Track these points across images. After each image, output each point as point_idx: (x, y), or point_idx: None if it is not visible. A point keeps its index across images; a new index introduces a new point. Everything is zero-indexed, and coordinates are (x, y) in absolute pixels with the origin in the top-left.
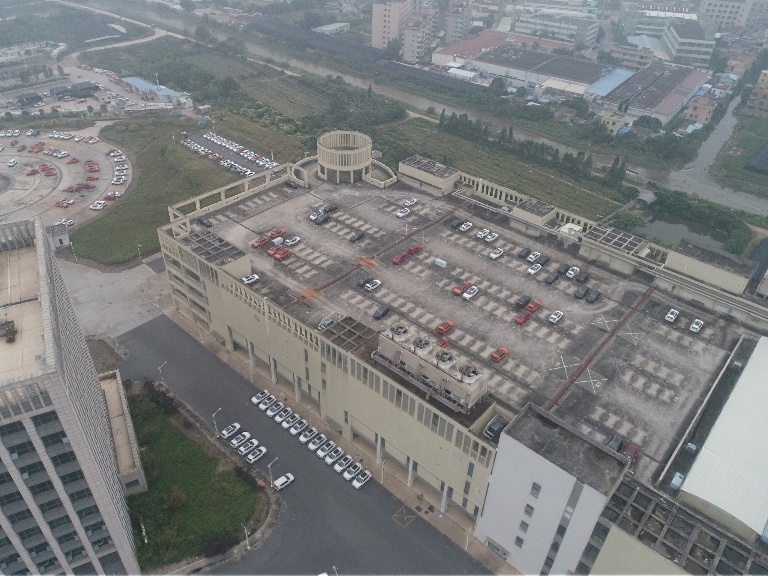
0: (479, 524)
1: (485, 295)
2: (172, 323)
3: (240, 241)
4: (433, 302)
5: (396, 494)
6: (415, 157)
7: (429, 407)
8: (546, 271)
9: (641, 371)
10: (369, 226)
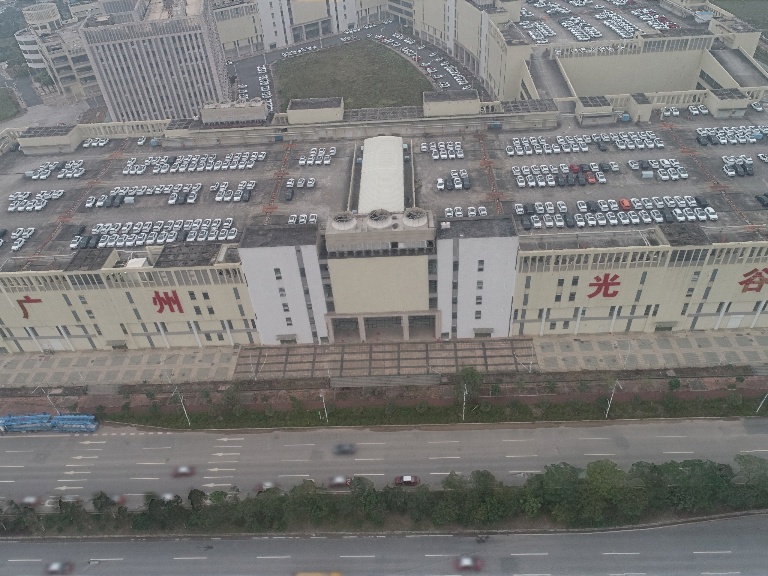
0: (264, 42)
1: None
2: (96, 97)
3: None
4: None
5: (240, 59)
6: None
7: (233, 7)
8: None
9: None
10: None
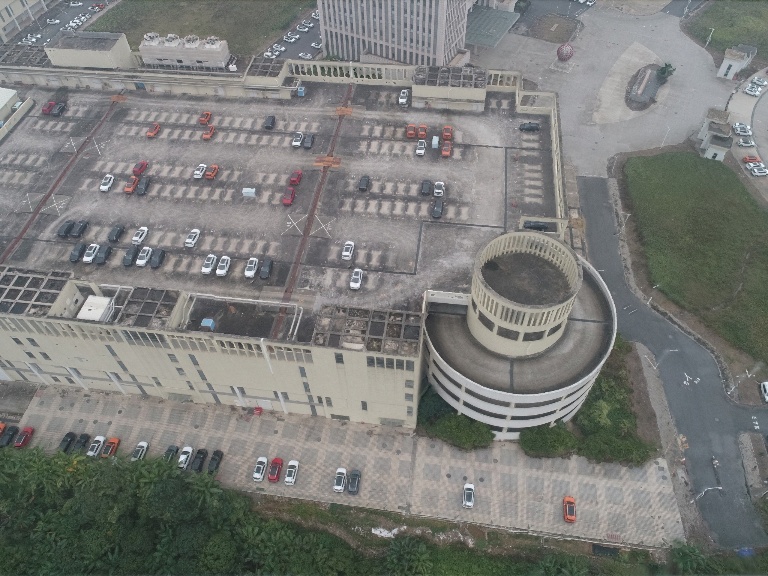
0: None
1: (186, 180)
2: None
3: (470, 129)
4: (233, 153)
5: None
6: (415, 348)
7: None
8: (127, 246)
9: (27, 169)
10: (370, 210)
